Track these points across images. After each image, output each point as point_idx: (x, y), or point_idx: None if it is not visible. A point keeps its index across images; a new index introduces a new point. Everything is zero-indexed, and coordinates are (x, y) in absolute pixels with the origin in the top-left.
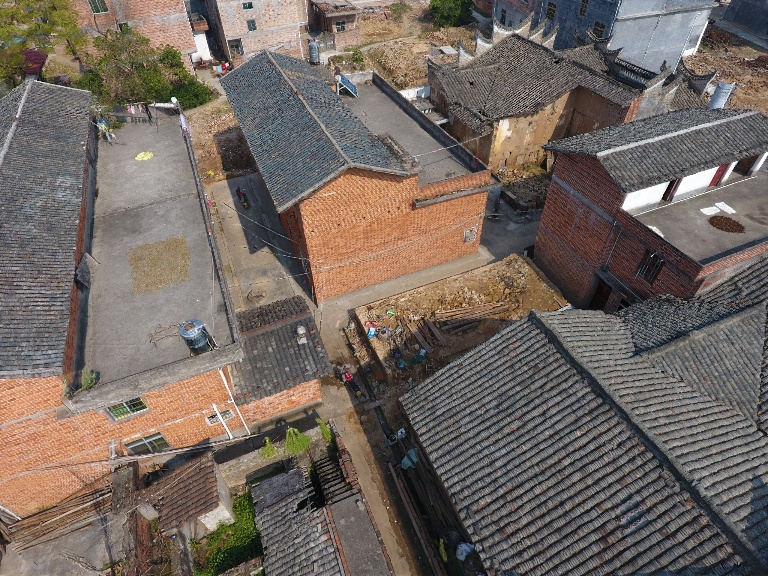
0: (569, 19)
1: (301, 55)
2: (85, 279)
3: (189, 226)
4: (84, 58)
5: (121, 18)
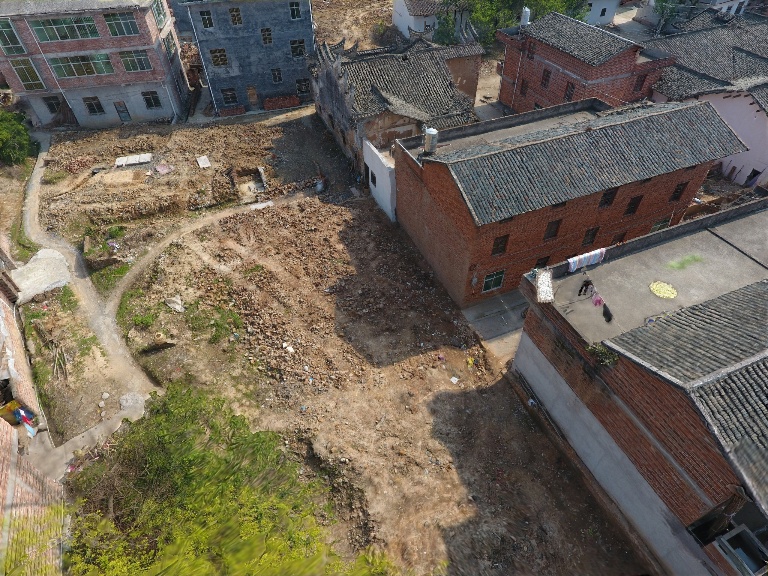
0: (253, 53)
1: (9, 311)
2: None
3: (761, 224)
4: None
5: None
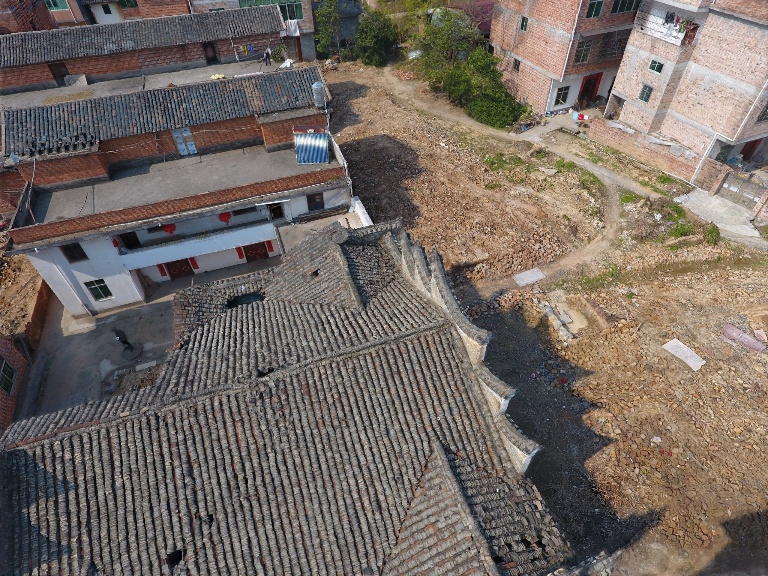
0: None
1: (691, 177)
2: (69, 82)
3: None
4: (493, 33)
5: (526, 11)
